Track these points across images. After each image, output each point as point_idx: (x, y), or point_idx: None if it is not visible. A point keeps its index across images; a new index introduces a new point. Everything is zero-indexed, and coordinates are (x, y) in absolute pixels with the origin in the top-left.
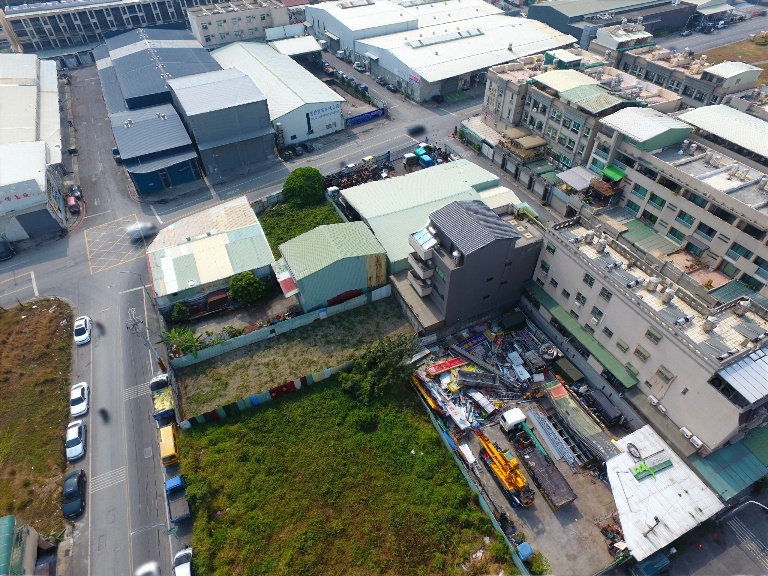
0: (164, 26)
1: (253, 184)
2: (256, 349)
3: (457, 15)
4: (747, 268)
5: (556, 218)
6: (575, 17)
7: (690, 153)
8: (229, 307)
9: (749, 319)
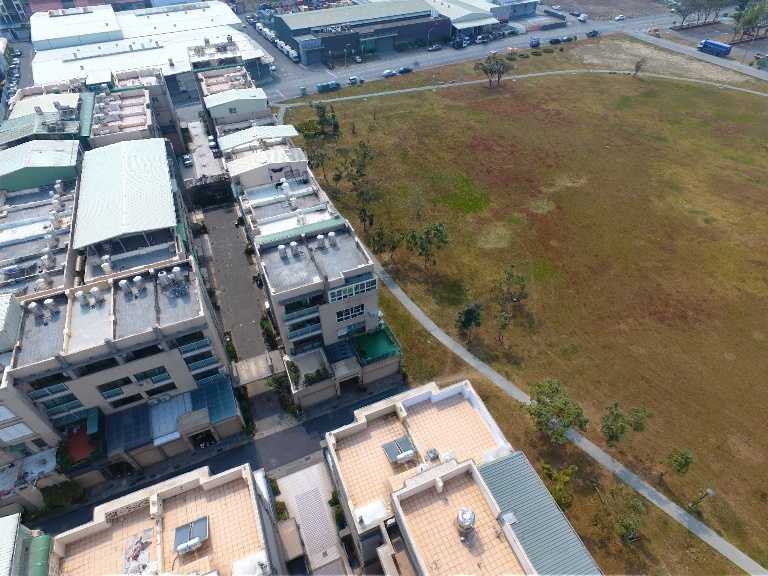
0: None
1: None
2: None
3: (184, 25)
4: None
5: None
6: (300, 30)
7: (59, 194)
8: None
9: None
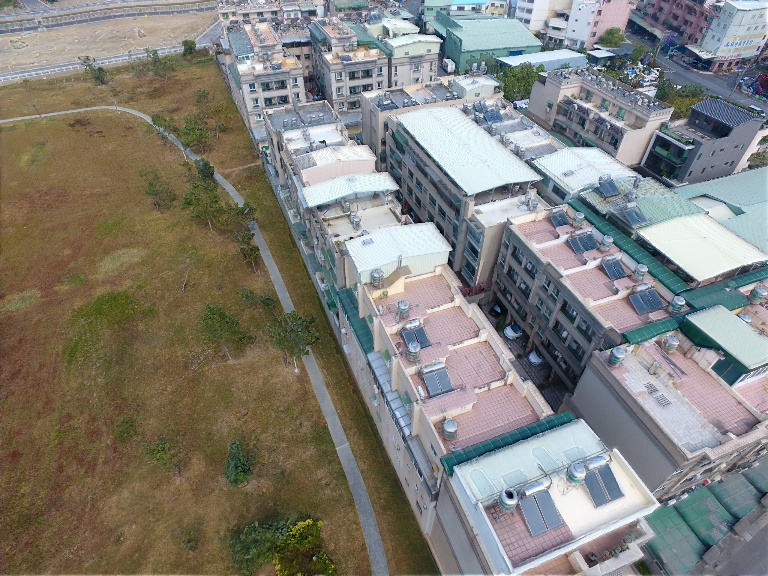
0: None
1: None
2: None
3: None
4: None
5: None
6: None
7: None
8: None
9: None
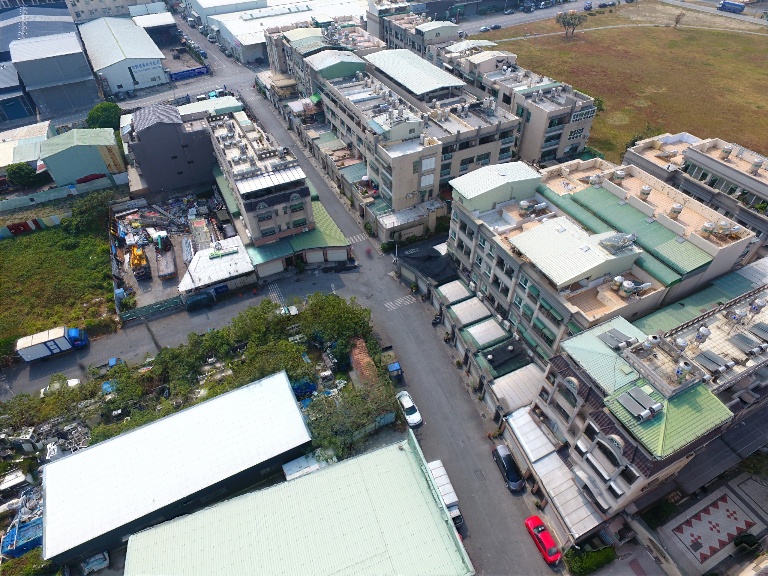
0: (47, 5)
1: (74, 118)
2: (18, 211)
3: None
4: (363, 151)
5: (291, 137)
6: None
7: (360, 80)
8: (9, 188)
9: (283, 159)
